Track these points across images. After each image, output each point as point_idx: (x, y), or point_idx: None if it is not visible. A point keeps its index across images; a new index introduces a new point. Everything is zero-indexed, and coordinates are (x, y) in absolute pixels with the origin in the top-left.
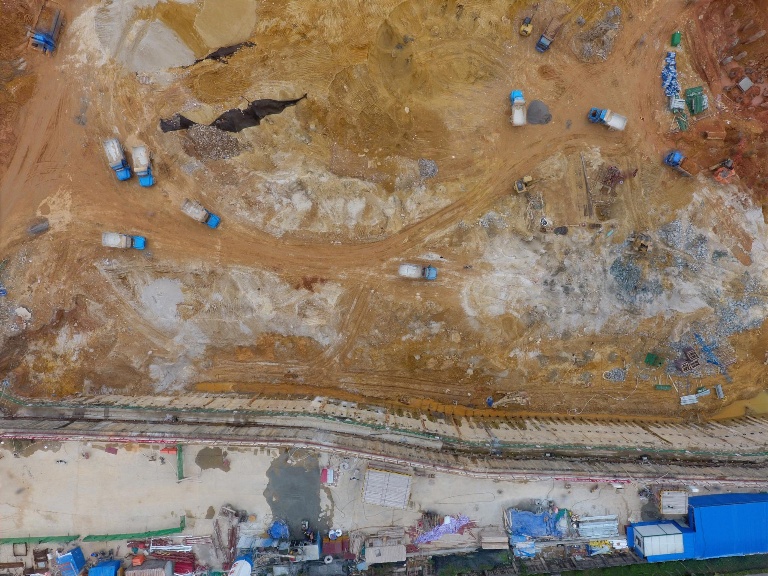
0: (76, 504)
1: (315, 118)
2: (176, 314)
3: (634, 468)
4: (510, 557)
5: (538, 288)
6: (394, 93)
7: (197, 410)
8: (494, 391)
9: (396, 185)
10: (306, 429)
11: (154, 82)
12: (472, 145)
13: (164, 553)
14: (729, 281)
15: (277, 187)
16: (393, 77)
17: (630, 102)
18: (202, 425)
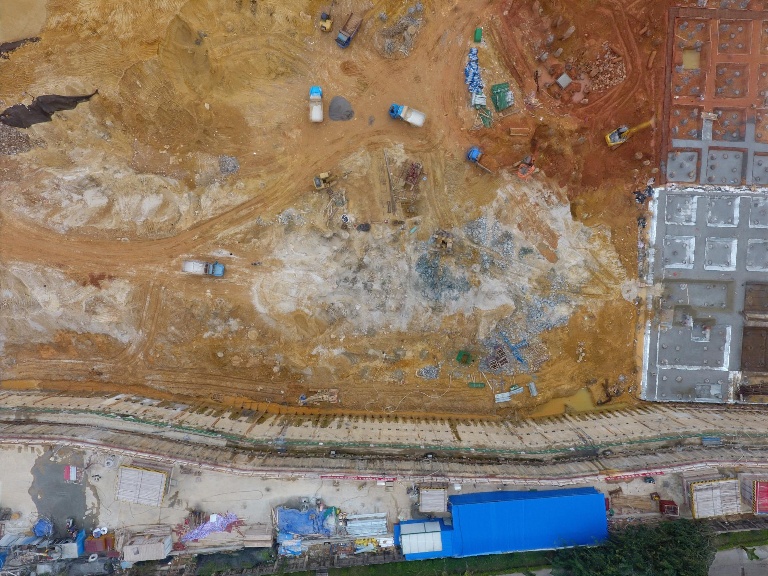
0: None
1: (110, 114)
2: None
3: (410, 466)
4: (273, 555)
5: (329, 285)
6: (196, 89)
7: None
8: (307, 389)
9: (196, 181)
10: (83, 427)
11: None
12: (273, 141)
13: None
14: (535, 278)
15: (64, 183)
16: (196, 73)
17: (433, 98)
18: None
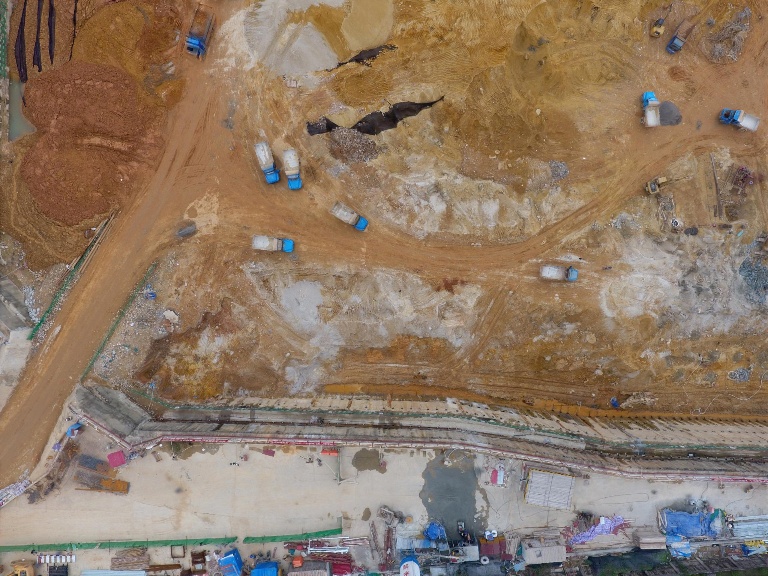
0: (233, 506)
1: (450, 120)
2: (317, 316)
3: None
4: (668, 557)
5: (677, 289)
6: (524, 95)
7: (343, 412)
8: (618, 391)
9: (528, 187)
10: (454, 430)
11: (301, 85)
12: (603, 146)
13: (321, 554)
14: None
15: (417, 189)
16: (523, 79)
17: (760, 103)
18: (350, 427)
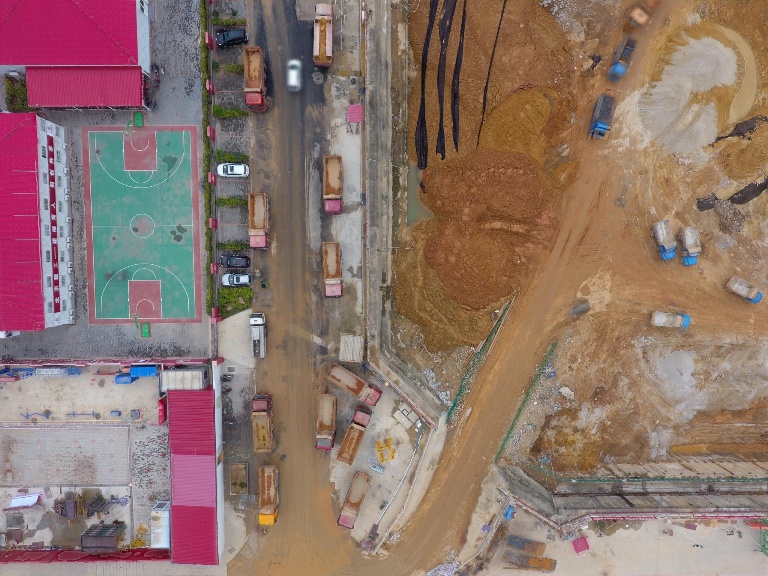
0: None
1: None
2: (693, 385)
3: None
4: None
5: None
6: None
7: (734, 480)
8: None
9: None
10: None
11: (692, 162)
12: None
13: None
14: None
15: None
16: None
17: None
18: (746, 495)
